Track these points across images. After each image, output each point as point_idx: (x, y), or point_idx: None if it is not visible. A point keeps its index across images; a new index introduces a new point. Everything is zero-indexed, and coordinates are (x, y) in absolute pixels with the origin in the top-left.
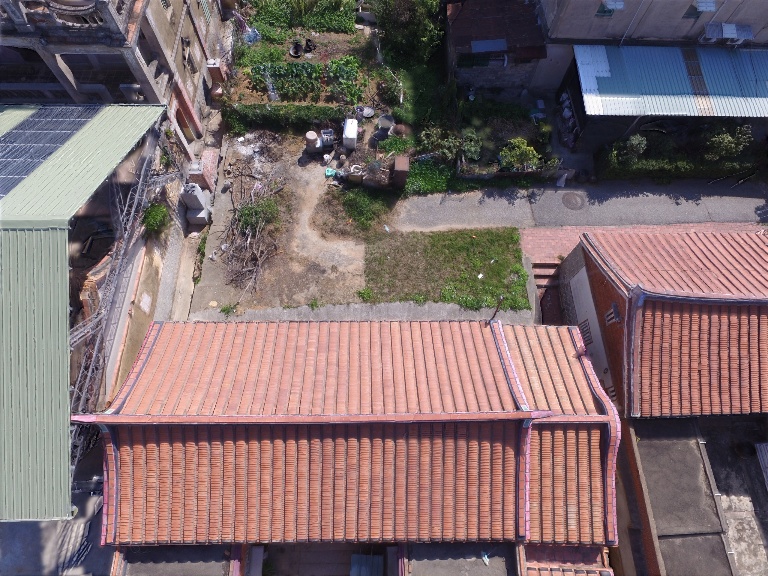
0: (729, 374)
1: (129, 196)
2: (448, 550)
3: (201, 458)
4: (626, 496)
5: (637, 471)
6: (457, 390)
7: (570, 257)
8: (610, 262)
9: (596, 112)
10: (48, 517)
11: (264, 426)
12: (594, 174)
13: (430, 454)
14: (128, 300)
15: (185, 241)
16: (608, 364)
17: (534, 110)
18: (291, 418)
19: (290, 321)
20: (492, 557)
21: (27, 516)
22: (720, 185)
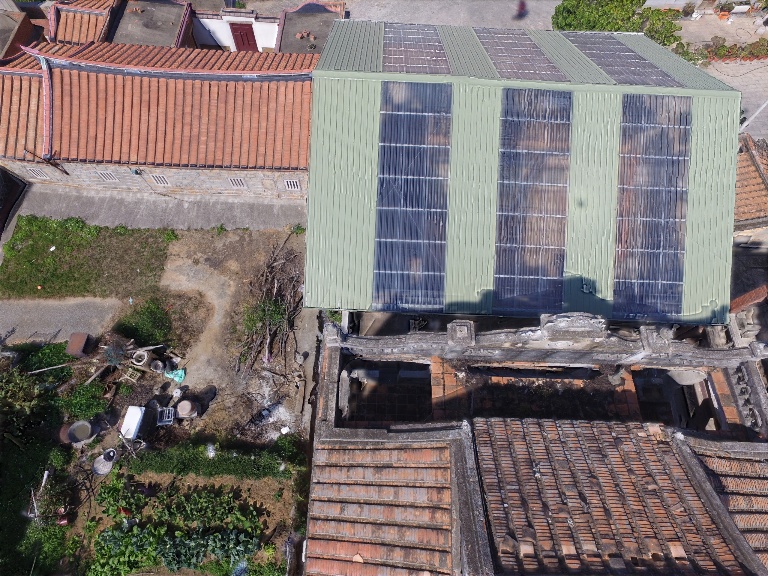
0: None
1: None
2: None
3: None
4: None
5: None
6: (93, 93)
7: None
8: None
9: None
10: None
11: None
12: None
13: None
14: None
15: None
16: None
17: None
18: (211, 71)
19: (222, 168)
20: None
21: None
22: None
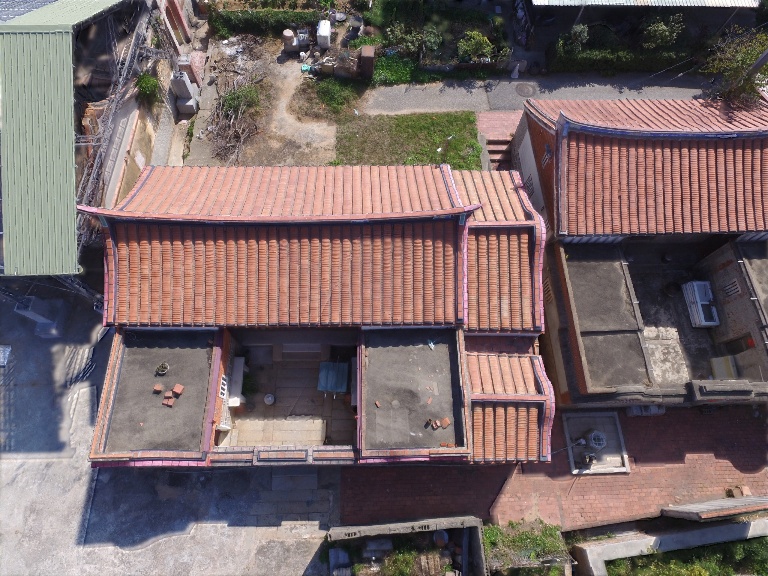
0: (646, 199)
1: (123, 51)
2: (399, 340)
3: (186, 254)
4: (556, 304)
5: (565, 279)
6: (406, 205)
7: (518, 128)
8: (545, 113)
9: (542, 2)
10: (58, 273)
11: (240, 228)
12: (545, 67)
13: (382, 252)
14: (124, 148)
15: (175, 127)
16: (544, 200)
17: (492, 14)
18: (262, 217)
19: (265, 166)
20: (437, 344)
21: (41, 272)
22: (661, 77)
